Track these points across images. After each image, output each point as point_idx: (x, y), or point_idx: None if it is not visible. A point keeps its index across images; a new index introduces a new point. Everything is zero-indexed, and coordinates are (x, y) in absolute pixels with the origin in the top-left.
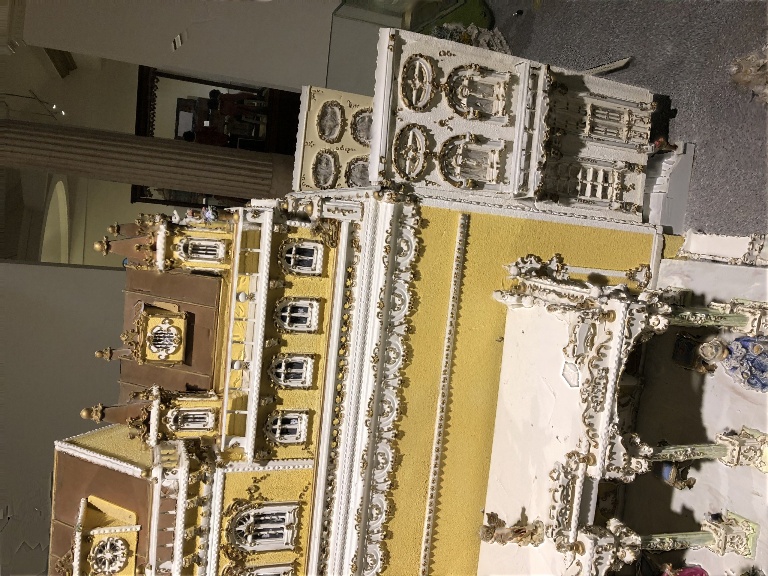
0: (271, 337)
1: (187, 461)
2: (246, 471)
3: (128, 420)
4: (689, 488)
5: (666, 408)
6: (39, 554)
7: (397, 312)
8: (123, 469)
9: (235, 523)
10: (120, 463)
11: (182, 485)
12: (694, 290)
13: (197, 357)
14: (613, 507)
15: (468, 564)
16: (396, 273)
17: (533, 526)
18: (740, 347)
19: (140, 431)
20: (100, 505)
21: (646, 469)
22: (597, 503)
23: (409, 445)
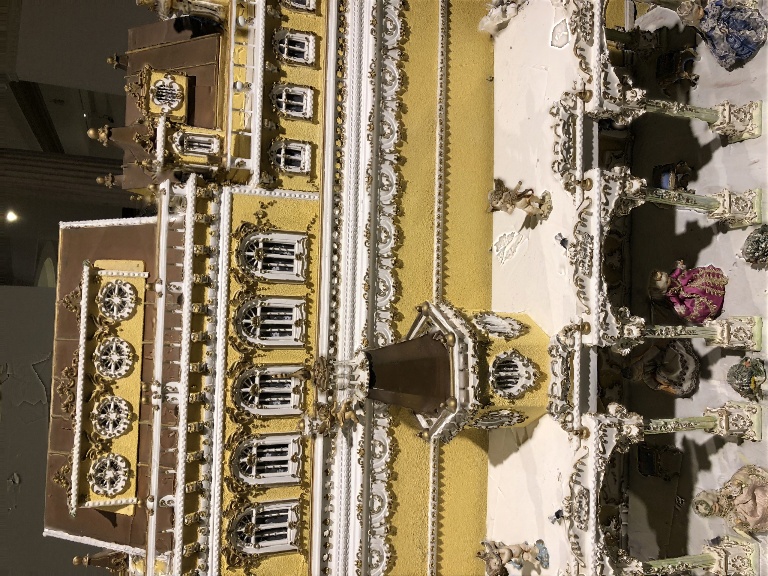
0: (271, 63)
1: (194, 174)
2: (253, 195)
3: (135, 134)
4: None
5: (658, 145)
6: (39, 425)
7: (390, 37)
8: (130, 221)
9: (244, 247)
10: (126, 219)
11: (190, 198)
12: (668, 26)
13: (199, 116)
14: (620, 265)
15: (481, 306)
16: None
17: (540, 197)
18: (714, 5)
19: (147, 147)
20: (107, 266)
21: (641, 96)
22: None
23: (412, 172)
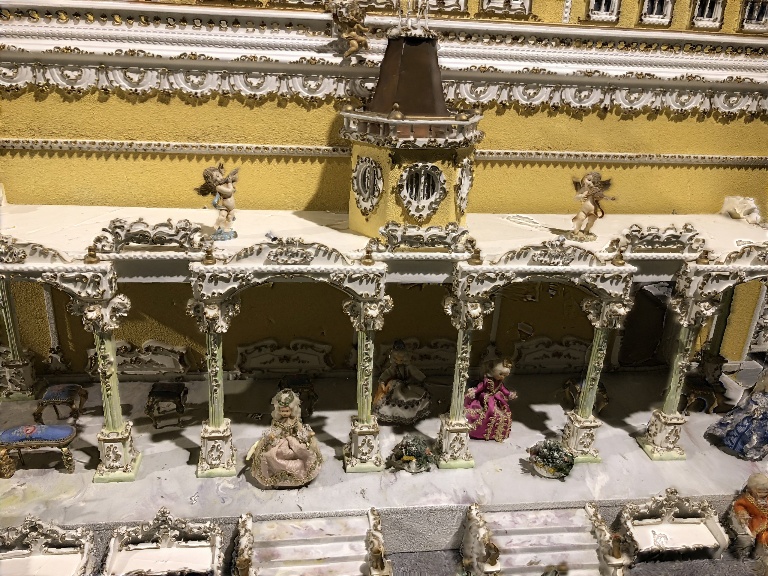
0: None
1: None
2: None
3: None
4: (565, 414)
5: (611, 389)
6: None
7: (722, 100)
8: None
9: None
10: None
11: None
12: (726, 393)
13: None
14: None
15: None
16: (760, 95)
17: None
18: None
19: None
20: None
21: (706, 314)
22: (495, 344)
23: (590, 125)
